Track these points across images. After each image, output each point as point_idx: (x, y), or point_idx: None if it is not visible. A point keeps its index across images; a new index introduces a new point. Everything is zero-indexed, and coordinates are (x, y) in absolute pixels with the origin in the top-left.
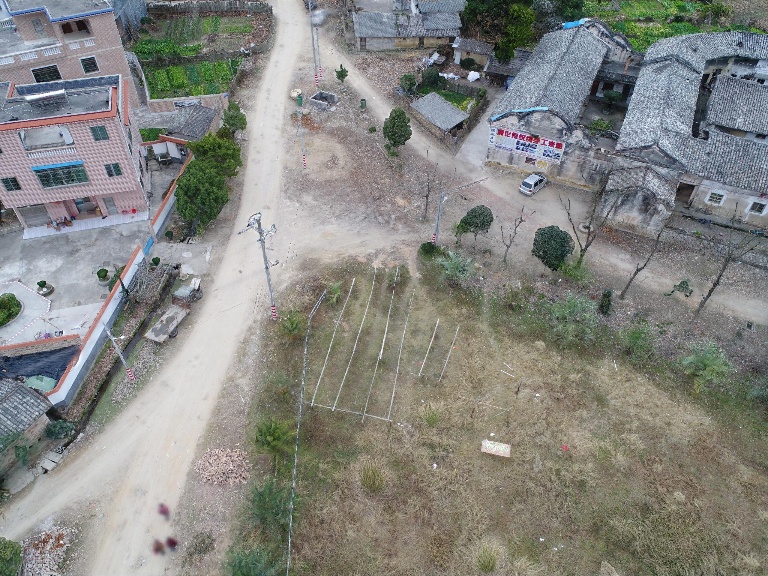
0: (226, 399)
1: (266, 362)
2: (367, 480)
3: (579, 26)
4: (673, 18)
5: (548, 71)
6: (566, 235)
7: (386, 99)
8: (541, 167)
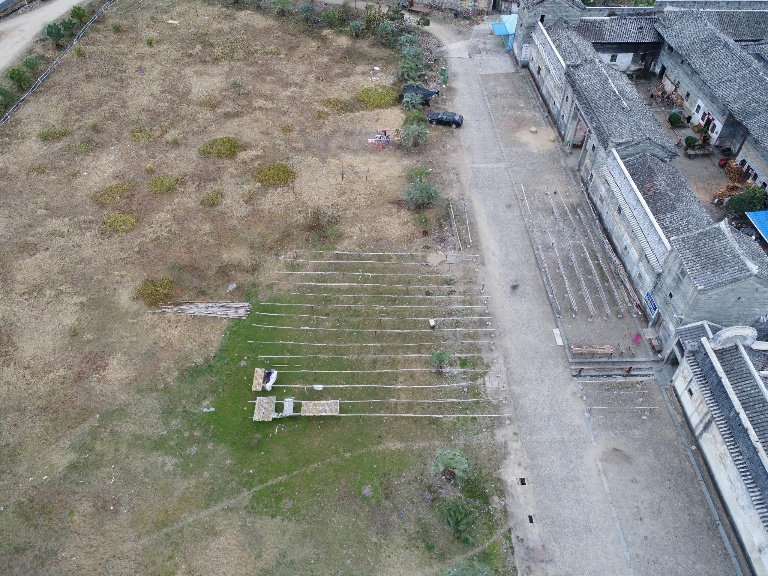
0: (67, 14)
1: None
2: (113, 24)
3: None
4: None
5: None
6: None
7: None
8: None
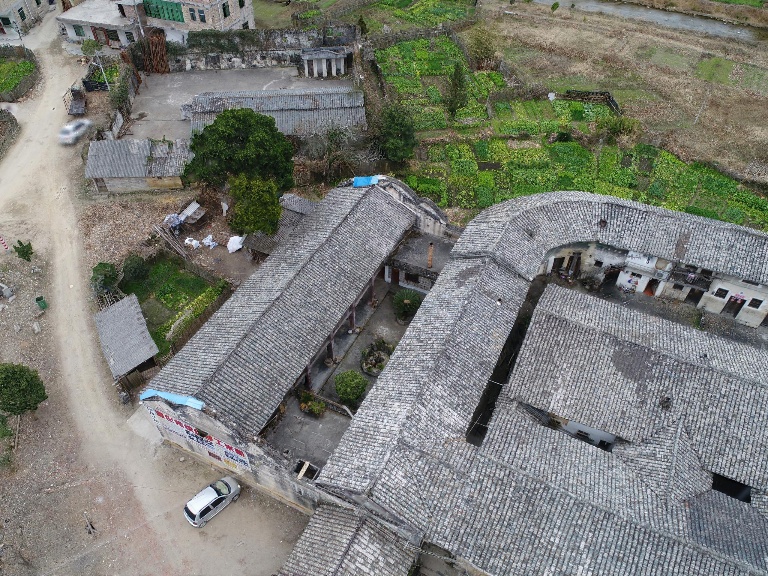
0: None
1: None
2: None
3: (370, 186)
4: (556, 136)
5: (276, 288)
6: None
7: (87, 289)
8: (232, 467)
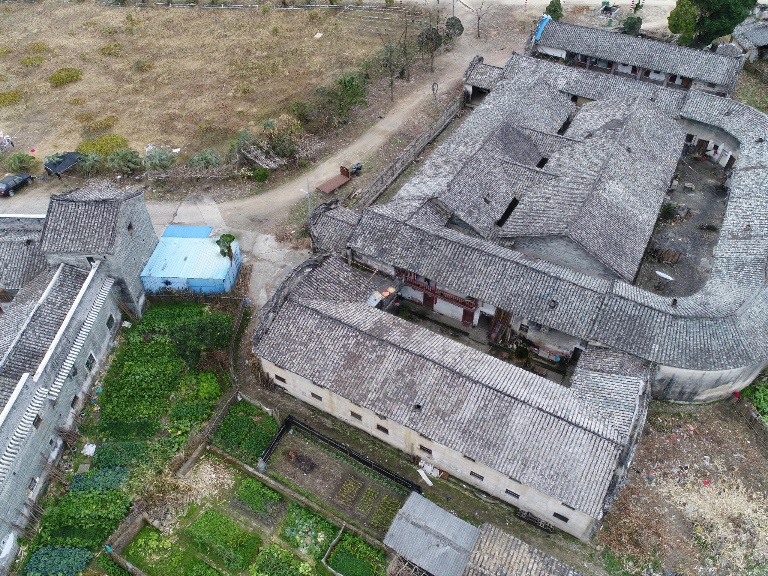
0: None
1: (376, 4)
2: None
3: None
4: None
5: None
6: (428, 32)
7: None
8: None
